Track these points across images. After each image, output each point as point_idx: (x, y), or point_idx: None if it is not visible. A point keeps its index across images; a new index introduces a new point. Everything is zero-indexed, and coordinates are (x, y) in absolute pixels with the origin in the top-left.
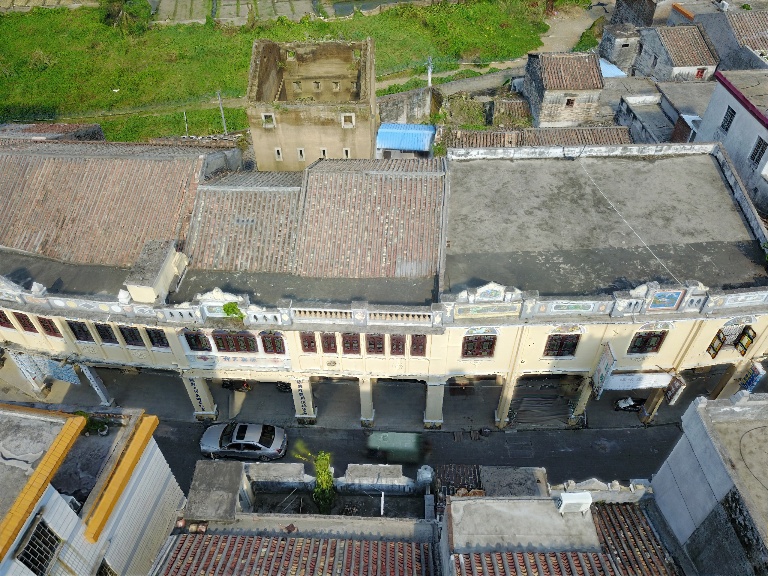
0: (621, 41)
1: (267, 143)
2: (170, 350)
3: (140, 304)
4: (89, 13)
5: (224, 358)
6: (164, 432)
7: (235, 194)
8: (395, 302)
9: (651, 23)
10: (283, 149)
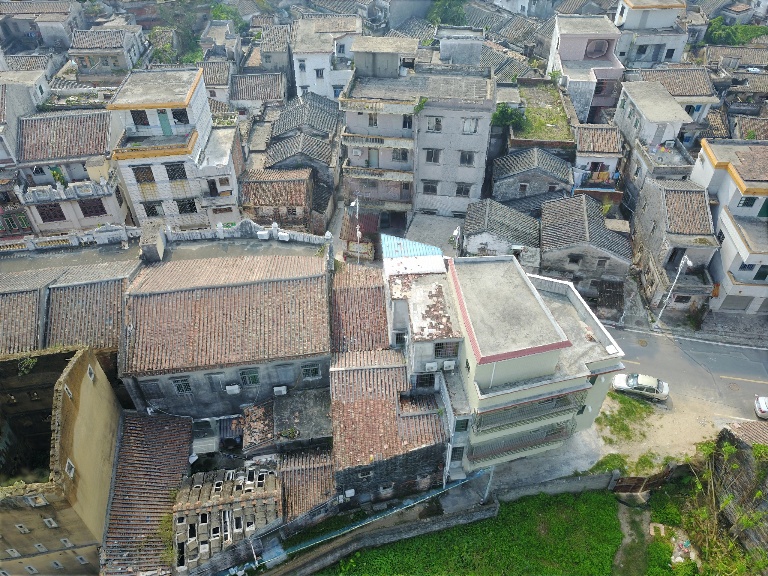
0: None
1: None
2: None
3: None
4: None
5: None
6: None
7: None
8: (10, 262)
9: None
10: None
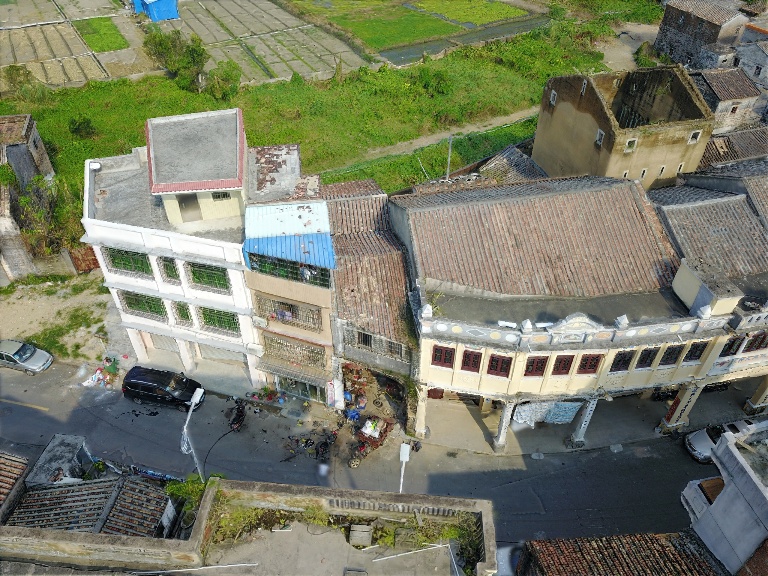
0: (722, 57)
1: (619, 167)
2: (699, 362)
3: (718, 317)
4: (162, 81)
5: (739, 360)
6: (642, 453)
7: (696, 209)
8: None
9: (715, 42)
10: (630, 171)
